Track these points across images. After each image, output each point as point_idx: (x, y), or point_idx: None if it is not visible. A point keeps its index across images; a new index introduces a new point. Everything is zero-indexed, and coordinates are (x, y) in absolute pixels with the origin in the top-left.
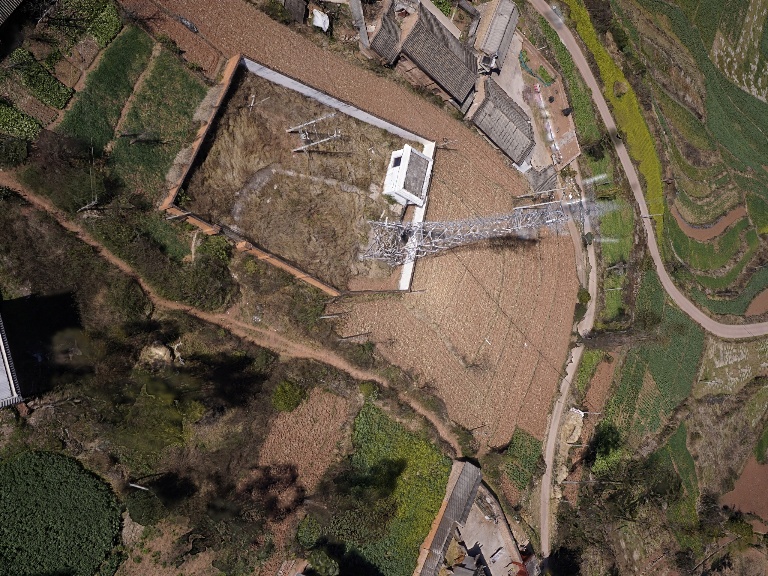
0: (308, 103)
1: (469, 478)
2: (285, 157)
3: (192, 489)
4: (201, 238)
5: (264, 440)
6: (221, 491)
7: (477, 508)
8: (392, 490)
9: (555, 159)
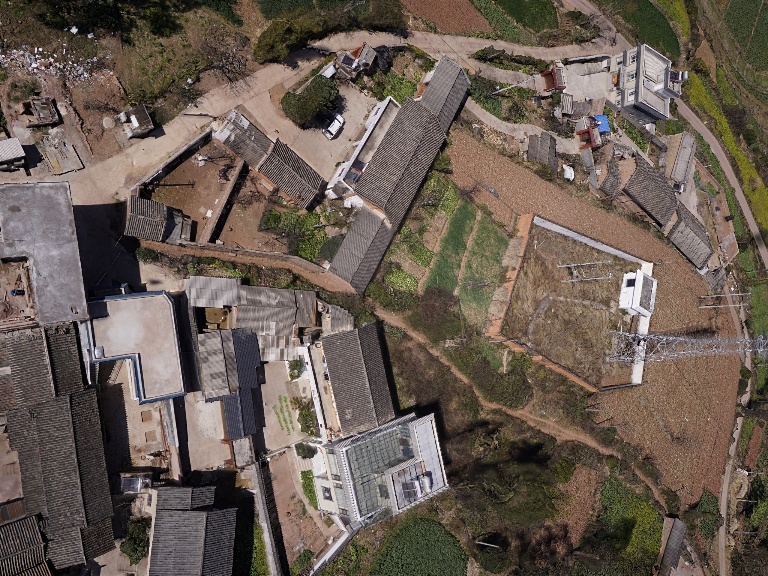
0: (567, 241)
1: (679, 532)
2: (557, 286)
3: (507, 544)
4: (512, 355)
5: None
6: (524, 545)
7: None
8: (628, 542)
9: (722, 259)
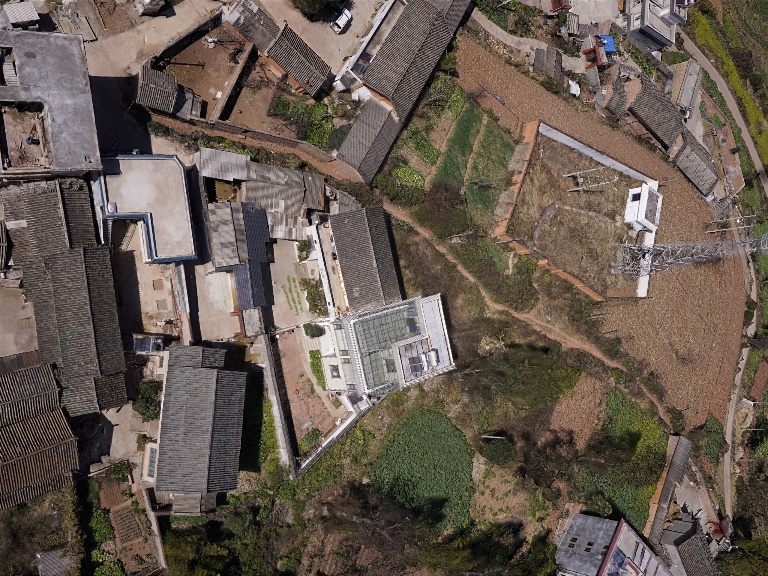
0: (573, 154)
1: (684, 449)
2: (563, 196)
3: (512, 444)
4: (517, 257)
5: (553, 410)
6: (529, 446)
7: (684, 475)
8: (633, 454)
9: (727, 190)
